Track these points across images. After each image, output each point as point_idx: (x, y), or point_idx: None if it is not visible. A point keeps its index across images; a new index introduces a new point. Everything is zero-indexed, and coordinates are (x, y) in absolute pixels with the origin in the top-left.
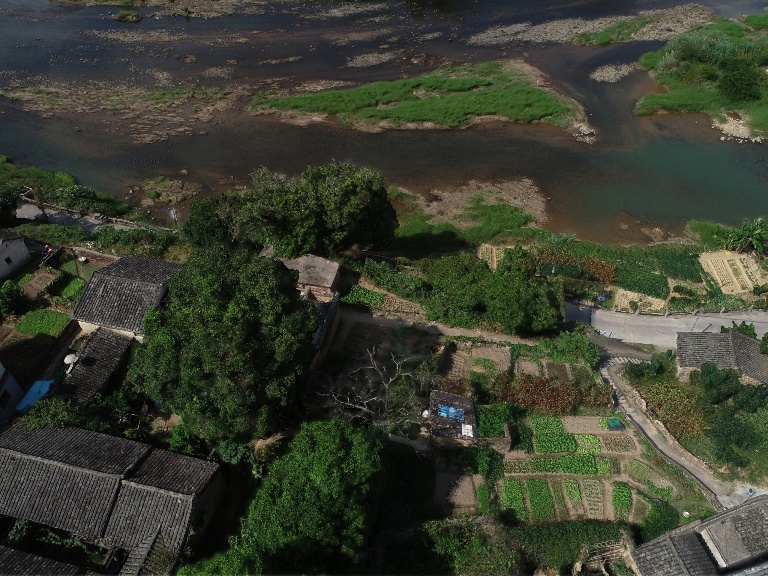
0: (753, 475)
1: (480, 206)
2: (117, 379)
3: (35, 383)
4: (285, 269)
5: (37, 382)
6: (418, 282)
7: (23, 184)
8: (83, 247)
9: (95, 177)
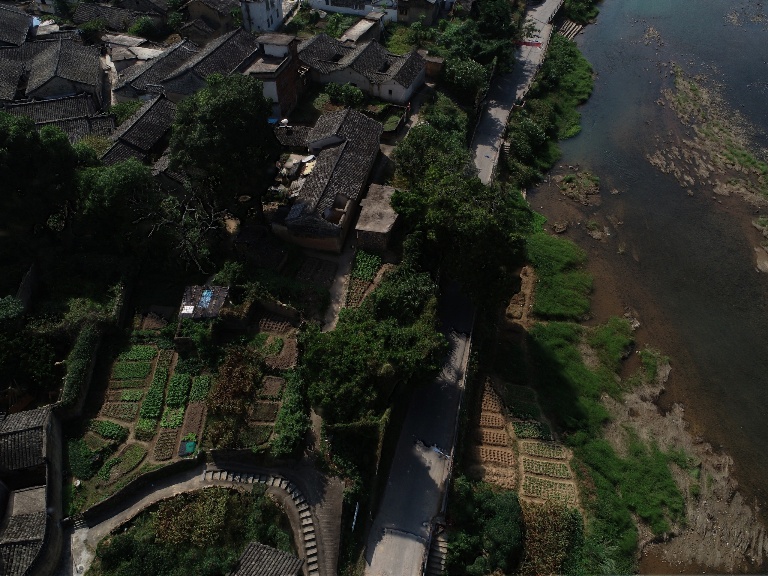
0: (90, 569)
1: (661, 458)
2: (285, 152)
3: (276, 119)
4: (242, 116)
5: (277, 120)
6: (378, 296)
7: (536, 105)
8: (418, 121)
9: (584, 145)
